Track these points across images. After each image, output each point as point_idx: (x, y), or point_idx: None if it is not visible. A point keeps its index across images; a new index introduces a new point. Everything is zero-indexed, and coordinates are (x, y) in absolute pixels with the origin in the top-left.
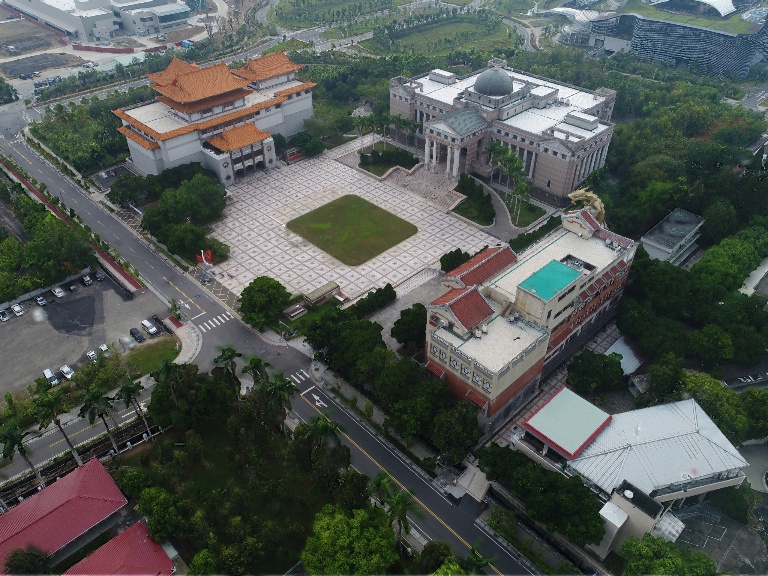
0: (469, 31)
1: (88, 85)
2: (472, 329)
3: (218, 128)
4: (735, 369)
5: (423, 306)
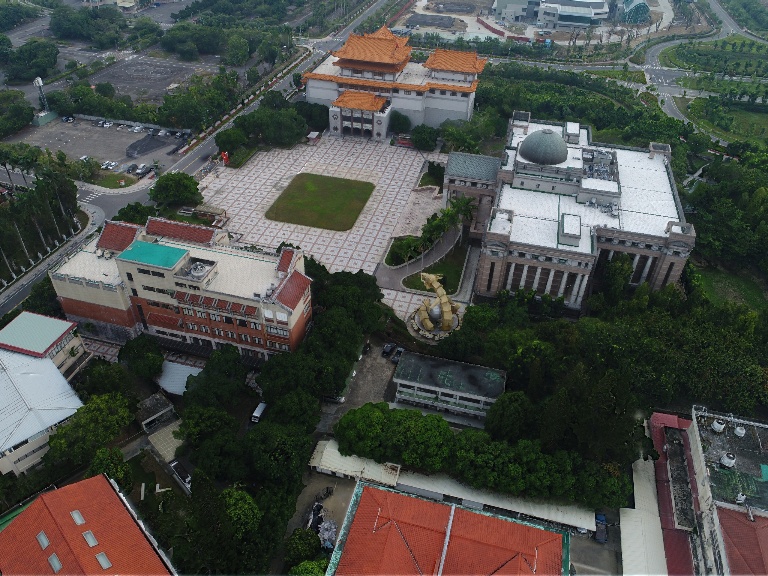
0: None
1: (422, 44)
2: (109, 251)
3: (354, 88)
4: None
5: None
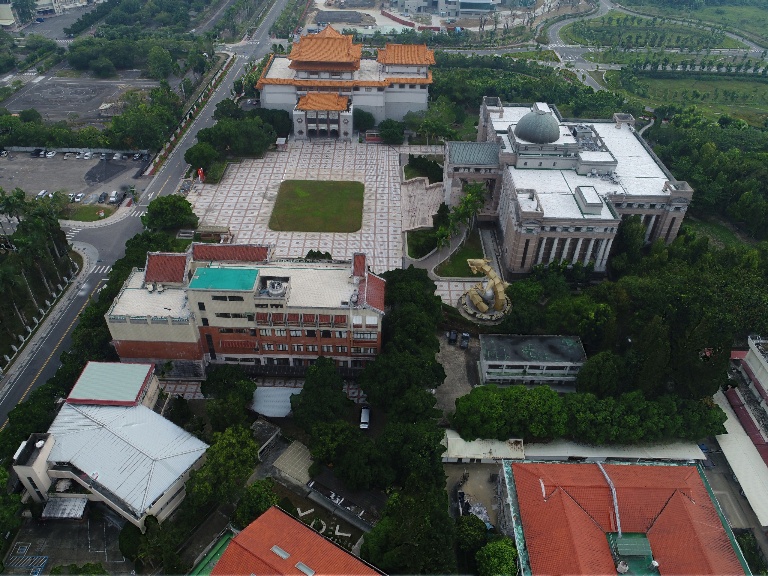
0: (737, 91)
1: None
2: None
3: (314, 90)
4: (337, 481)
5: None
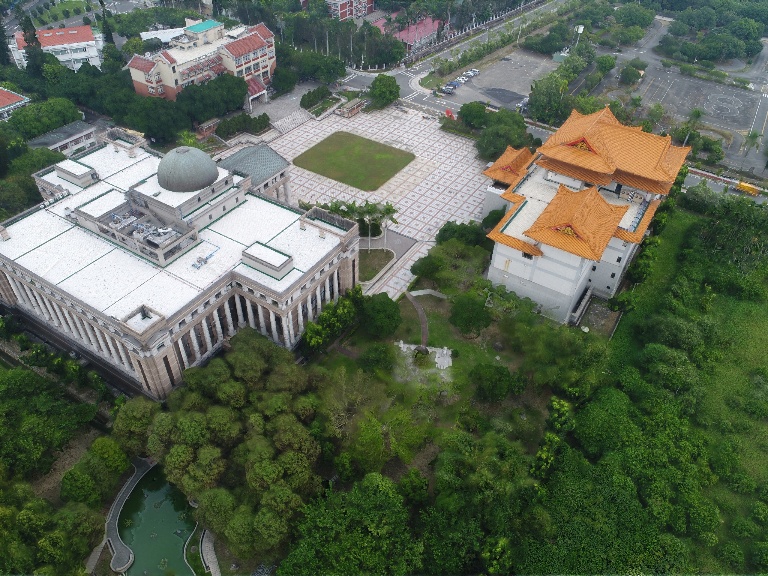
0: None
1: None
2: None
3: None
4: None
5: (279, 73)
